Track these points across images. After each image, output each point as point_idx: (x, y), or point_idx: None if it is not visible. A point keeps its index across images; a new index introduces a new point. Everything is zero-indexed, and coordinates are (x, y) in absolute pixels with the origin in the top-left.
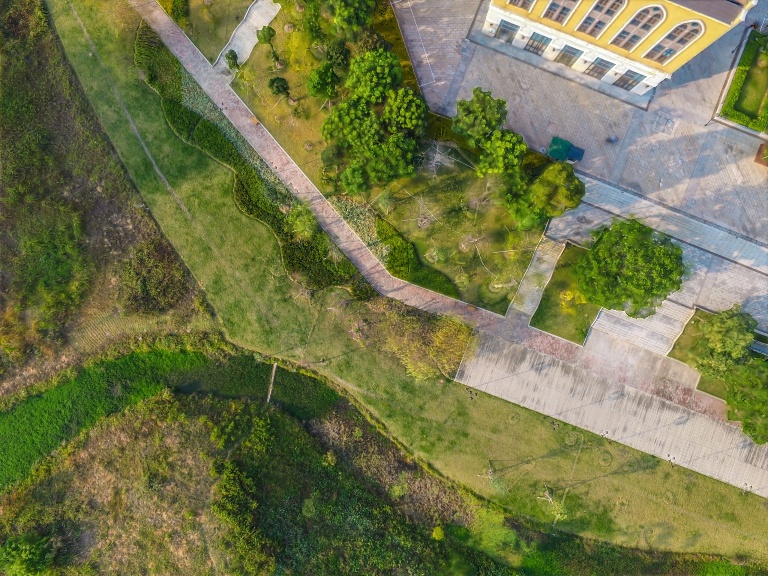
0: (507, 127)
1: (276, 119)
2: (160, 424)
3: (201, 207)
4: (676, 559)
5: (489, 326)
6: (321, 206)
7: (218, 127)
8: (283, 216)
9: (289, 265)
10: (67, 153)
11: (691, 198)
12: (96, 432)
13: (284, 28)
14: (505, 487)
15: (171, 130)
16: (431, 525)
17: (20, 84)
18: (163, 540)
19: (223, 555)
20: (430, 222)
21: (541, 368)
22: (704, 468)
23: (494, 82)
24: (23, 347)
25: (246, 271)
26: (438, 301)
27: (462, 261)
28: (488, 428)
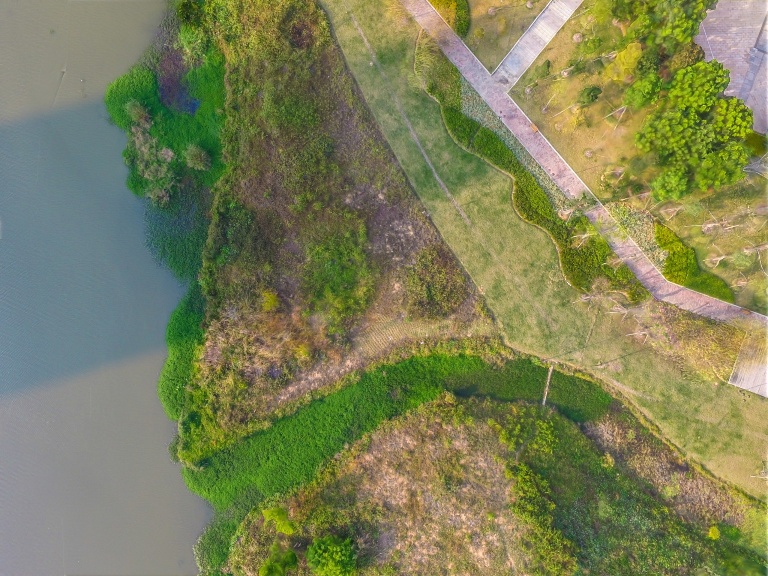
0: None
1: (556, 127)
2: (445, 427)
3: (480, 213)
4: None
5: (761, 329)
6: (598, 212)
7: (497, 135)
8: (562, 222)
9: (569, 270)
10: (349, 161)
11: None
12: (379, 435)
13: (573, 38)
14: None
15: (450, 138)
16: (705, 525)
17: (306, 93)
18: (463, 541)
19: (522, 555)
20: (714, 228)
21: None
22: None
23: None
24: (312, 352)
25: (525, 276)
26: (712, 305)
27: (742, 266)
28: (761, 429)
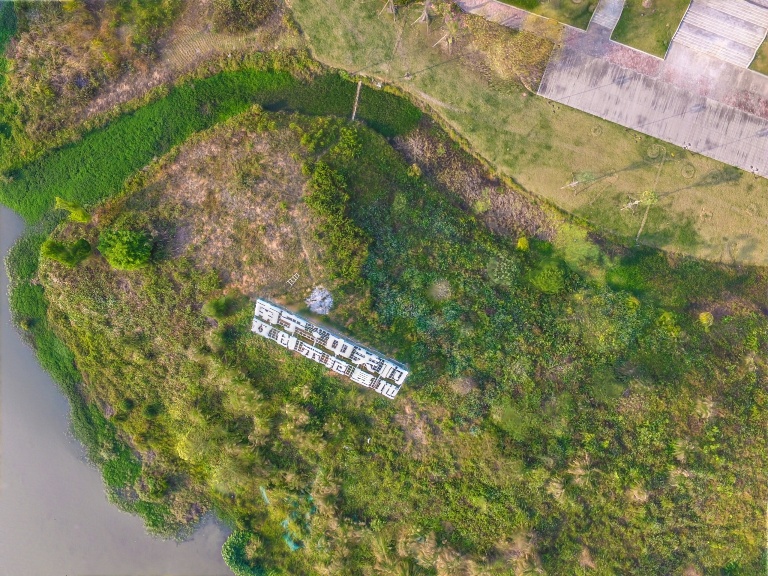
0: None
1: None
2: (250, 135)
3: None
4: (760, 274)
5: (570, 41)
6: None
7: None
8: None
9: None
10: None
11: None
12: (187, 146)
13: None
14: (588, 200)
15: None
16: (515, 238)
17: None
18: (257, 233)
19: (316, 247)
20: None
21: (623, 82)
22: None
23: None
24: (117, 60)
25: None
26: (520, 17)
27: None
28: (571, 141)
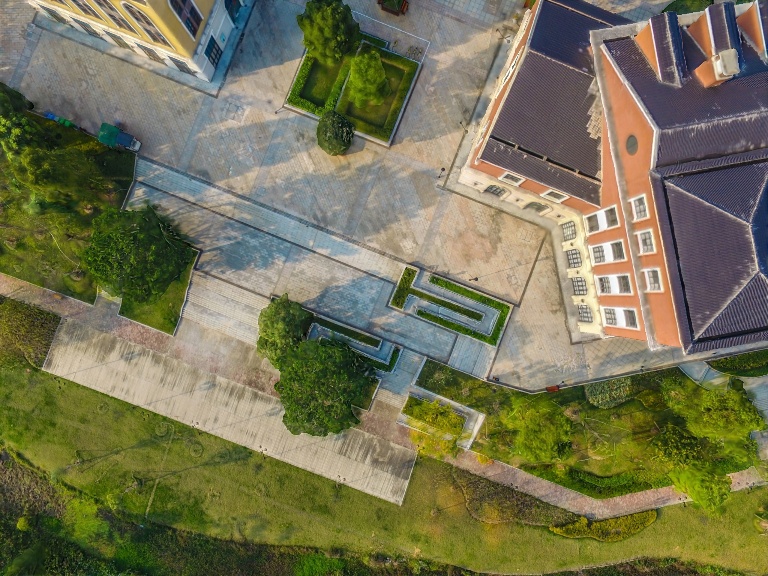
0: (73, 113)
1: None
2: None
3: None
4: (272, 552)
5: (78, 315)
6: None
7: None
8: None
9: None
10: None
11: (261, 186)
12: None
13: None
14: (95, 478)
15: None
16: (19, 516)
17: None
18: None
19: None
20: (3, 209)
21: (131, 358)
22: (297, 460)
23: (60, 68)
24: None
25: None
26: (26, 289)
27: (40, 249)
28: (76, 418)
